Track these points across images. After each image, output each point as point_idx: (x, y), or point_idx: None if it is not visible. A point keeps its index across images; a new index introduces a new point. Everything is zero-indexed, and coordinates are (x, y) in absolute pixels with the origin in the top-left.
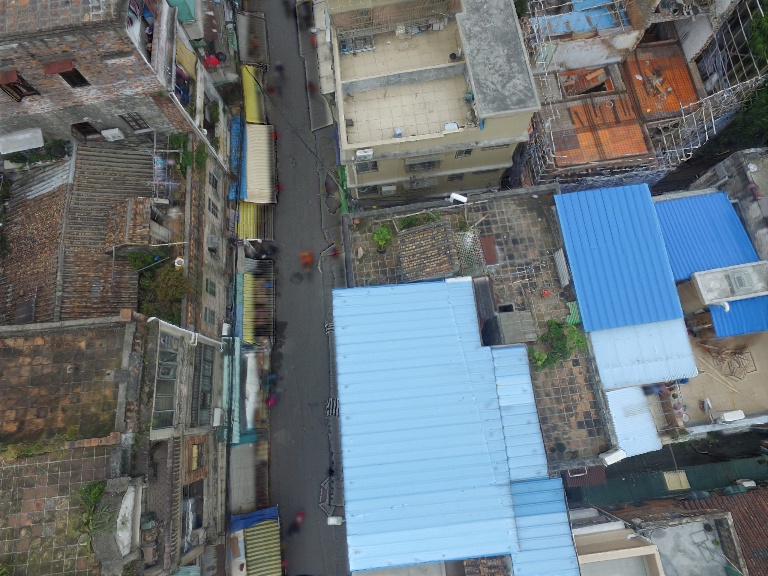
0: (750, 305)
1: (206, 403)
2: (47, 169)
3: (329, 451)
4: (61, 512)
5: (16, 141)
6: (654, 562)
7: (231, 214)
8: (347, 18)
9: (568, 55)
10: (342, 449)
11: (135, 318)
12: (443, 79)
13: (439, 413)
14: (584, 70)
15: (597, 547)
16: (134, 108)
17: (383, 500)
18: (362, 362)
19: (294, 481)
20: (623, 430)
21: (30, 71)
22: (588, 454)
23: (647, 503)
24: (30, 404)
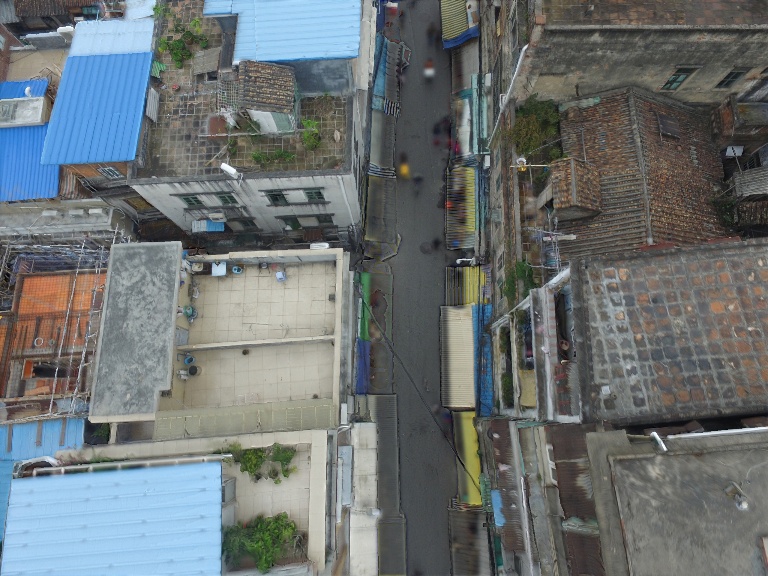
0: (7, 98)
1: None
2: None
3: (400, 79)
4: None
5: None
6: None
7: (490, 292)
8: None
9: None
10: None
11: None
12: None
13: None
14: None
15: None
16: None
17: None
18: (339, 2)
19: (435, 84)
20: None
21: None
22: None
23: None
24: None
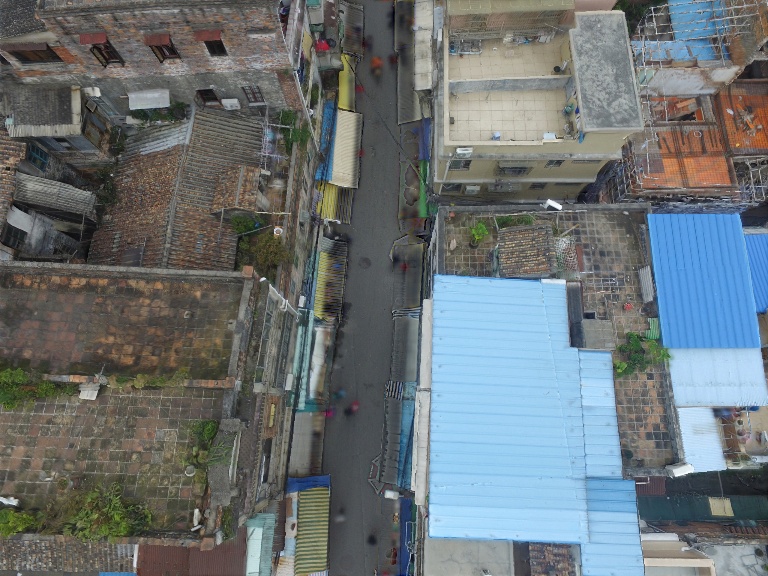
0: None
1: (281, 367)
2: (163, 129)
3: (384, 430)
4: (169, 443)
5: (145, 99)
6: (708, 575)
7: (315, 193)
8: (463, 21)
9: (664, 81)
10: (431, 423)
11: (254, 276)
12: (544, 90)
13: (524, 403)
14: (676, 98)
15: (652, 553)
16: (258, 82)
17: (465, 476)
18: (457, 346)
19: (342, 455)
20: (690, 446)
21: (180, 36)
22: (654, 464)
23: (691, 524)
24: (147, 342)
